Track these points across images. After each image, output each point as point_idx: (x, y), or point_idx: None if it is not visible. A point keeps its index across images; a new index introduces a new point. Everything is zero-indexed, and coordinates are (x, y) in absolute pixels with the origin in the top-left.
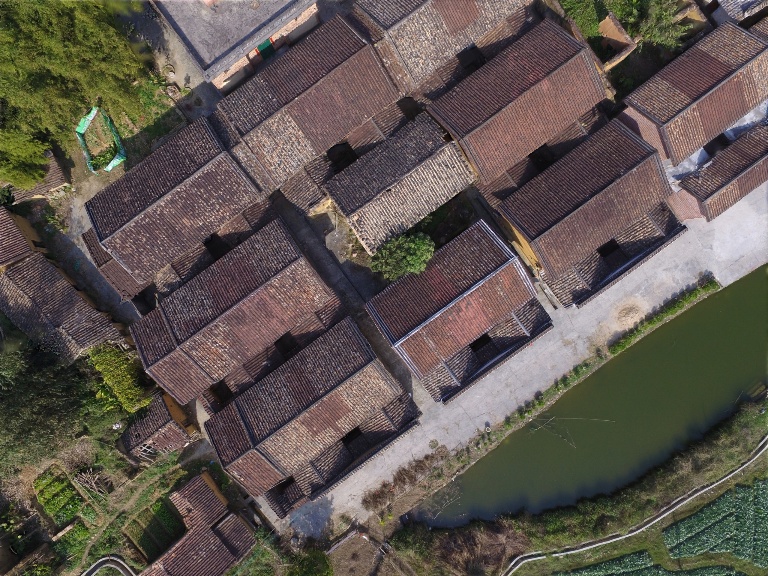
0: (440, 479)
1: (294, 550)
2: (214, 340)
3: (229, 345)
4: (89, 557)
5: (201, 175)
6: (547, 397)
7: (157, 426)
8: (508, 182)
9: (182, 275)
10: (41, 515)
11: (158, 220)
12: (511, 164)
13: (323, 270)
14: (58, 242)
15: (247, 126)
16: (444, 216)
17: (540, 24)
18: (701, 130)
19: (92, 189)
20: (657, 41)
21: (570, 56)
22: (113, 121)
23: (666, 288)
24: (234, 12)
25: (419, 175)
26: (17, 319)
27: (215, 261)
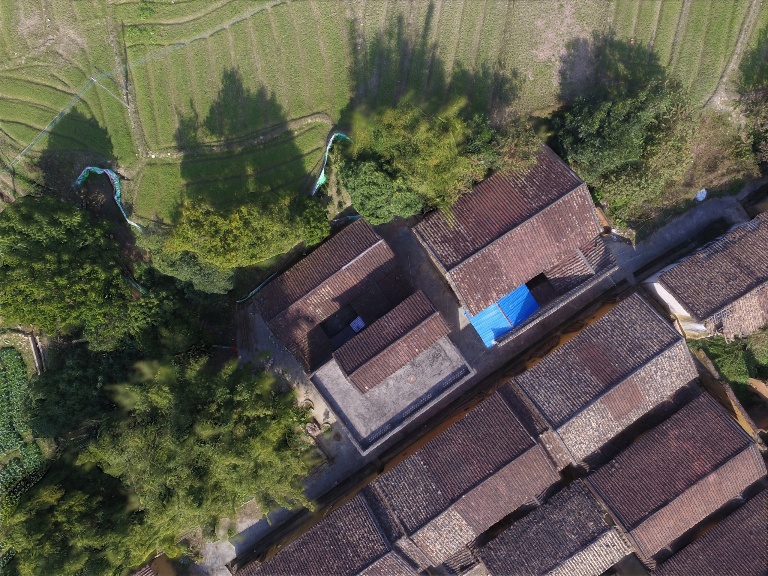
0: None
1: None
2: None
3: None
4: None
5: (366, 571)
6: None
7: None
8: None
9: None
10: None
11: None
12: (670, 540)
13: None
14: (192, 573)
15: (412, 521)
16: None
17: (699, 398)
18: None
19: (227, 520)
20: None
21: (738, 449)
22: None
23: None
24: (391, 386)
25: (580, 557)
26: None
27: None
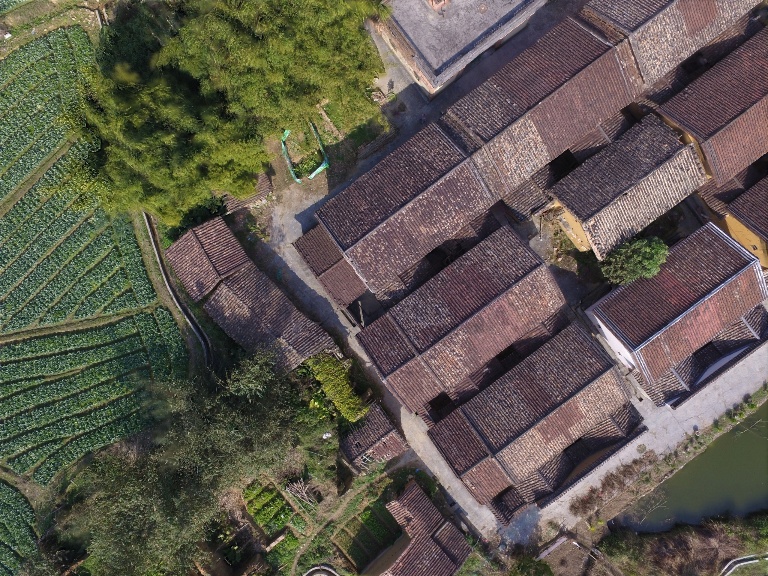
0: (648, 484)
1: (502, 557)
2: (452, 348)
3: (465, 353)
4: (300, 567)
5: (443, 182)
6: (756, 400)
7: (378, 435)
8: (733, 184)
9: (406, 283)
10: (252, 526)
11: (398, 228)
12: (745, 166)
13: None
14: (259, 251)
15: (488, 132)
16: None
17: None
18: None
19: (293, 197)
20: None
21: None
22: (317, 128)
23: None
24: (461, 16)
25: (655, 178)
26: (232, 329)
27: None
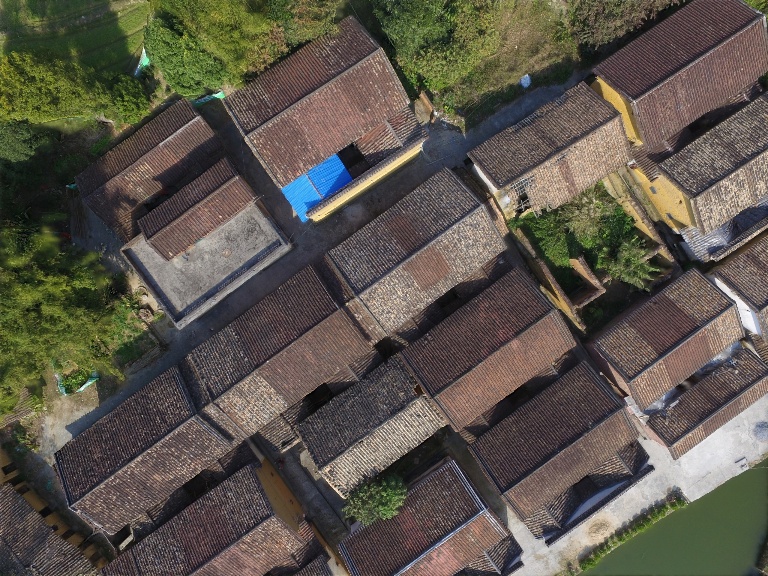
0: None
1: None
2: None
3: None
4: None
5: (172, 437)
6: None
7: None
8: (480, 420)
9: (154, 516)
10: None
11: (129, 479)
12: (482, 411)
13: (298, 488)
14: (29, 461)
15: (218, 387)
16: None
17: (511, 273)
18: (667, 379)
19: (64, 408)
20: None
21: (539, 316)
22: None
23: (635, 504)
24: (206, 260)
25: (391, 426)
26: None
27: (188, 497)
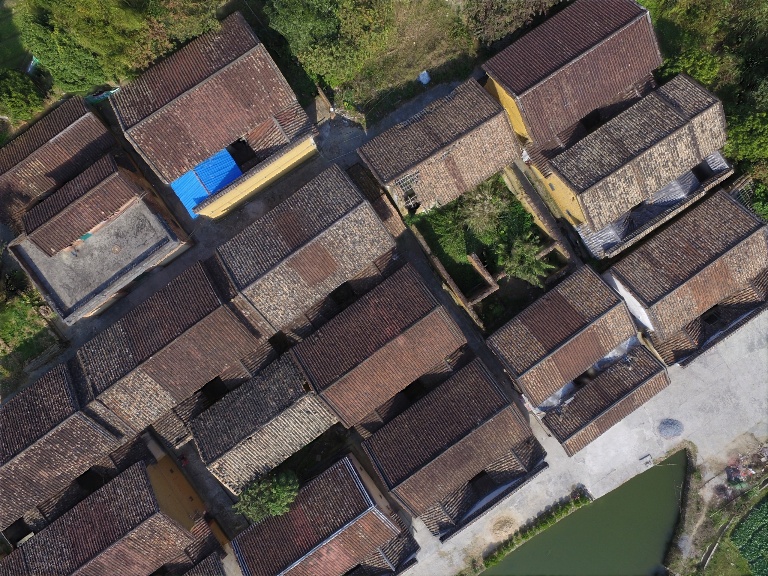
0: None
1: None
2: None
3: None
4: None
5: (55, 433)
6: None
7: None
8: (375, 416)
9: (47, 513)
10: None
11: (13, 476)
12: (373, 408)
13: (201, 485)
14: None
15: (102, 383)
16: (319, 436)
17: (402, 269)
18: (559, 375)
19: None
20: (521, 278)
21: (425, 313)
22: None
23: (540, 501)
24: (95, 256)
25: (280, 422)
26: None
27: (83, 493)
